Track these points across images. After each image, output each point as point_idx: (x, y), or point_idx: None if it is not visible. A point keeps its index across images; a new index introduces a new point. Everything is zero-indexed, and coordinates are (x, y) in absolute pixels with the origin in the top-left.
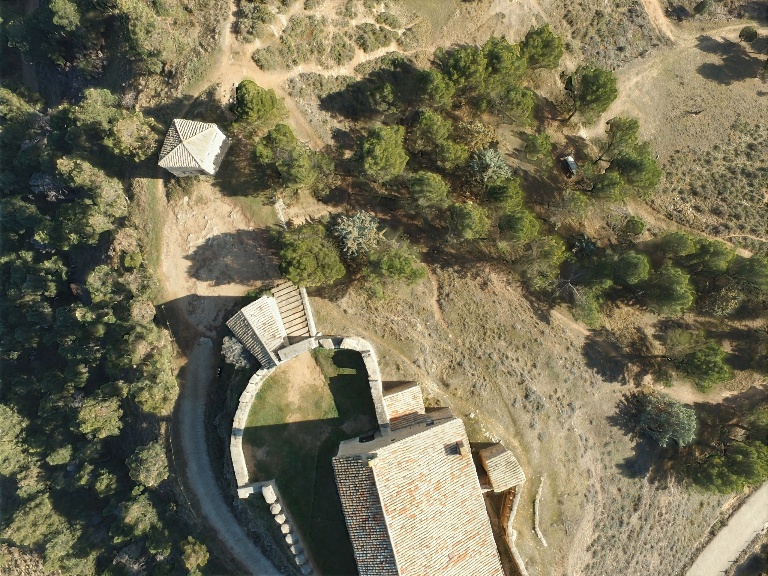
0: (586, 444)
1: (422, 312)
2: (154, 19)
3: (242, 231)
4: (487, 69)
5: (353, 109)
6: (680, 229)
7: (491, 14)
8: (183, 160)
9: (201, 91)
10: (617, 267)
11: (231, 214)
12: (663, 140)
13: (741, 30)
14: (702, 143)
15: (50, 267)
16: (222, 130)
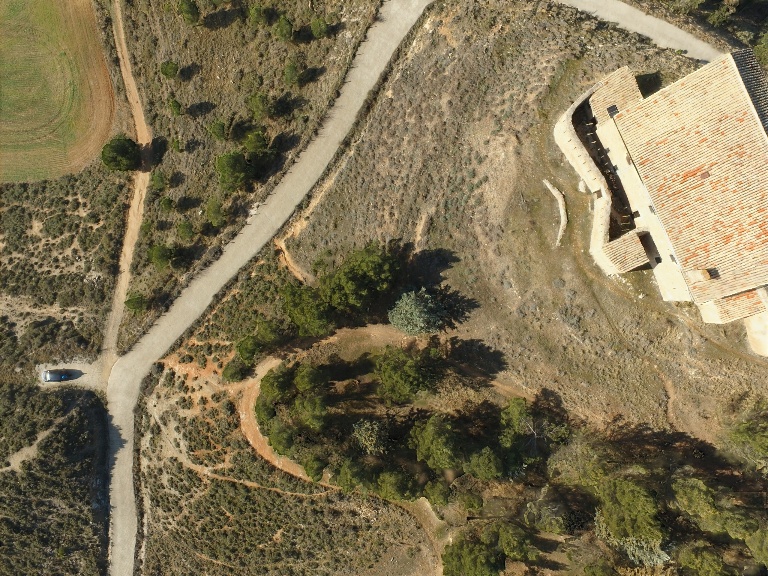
0: (502, 279)
1: (686, 386)
2: None
3: None
4: None
5: None
6: (374, 492)
7: None
8: None
9: None
10: None
11: None
12: None
13: None
14: None
15: None
16: None
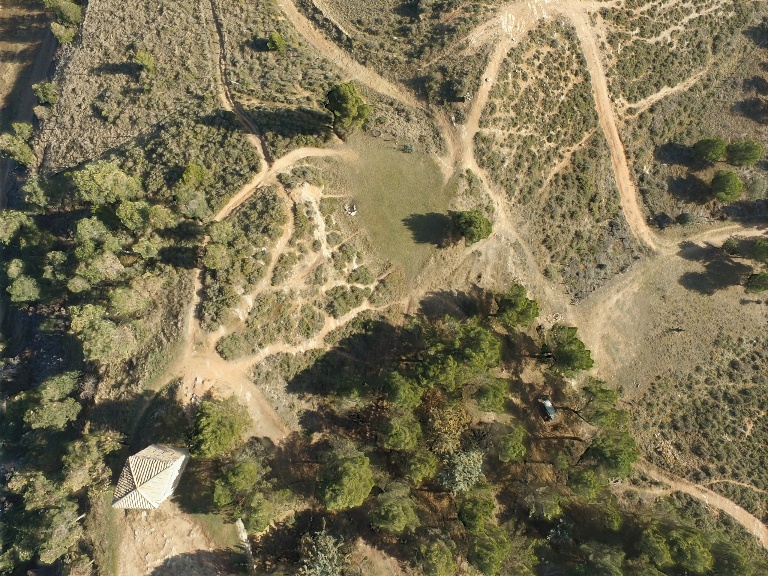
0: None
1: None
2: (110, 339)
3: (202, 552)
4: (458, 366)
5: (322, 385)
6: (660, 473)
7: (467, 254)
8: (138, 503)
9: (162, 386)
10: (592, 574)
11: (191, 533)
12: (644, 365)
13: (723, 243)
14: (684, 364)
15: (4, 566)
16: (183, 435)
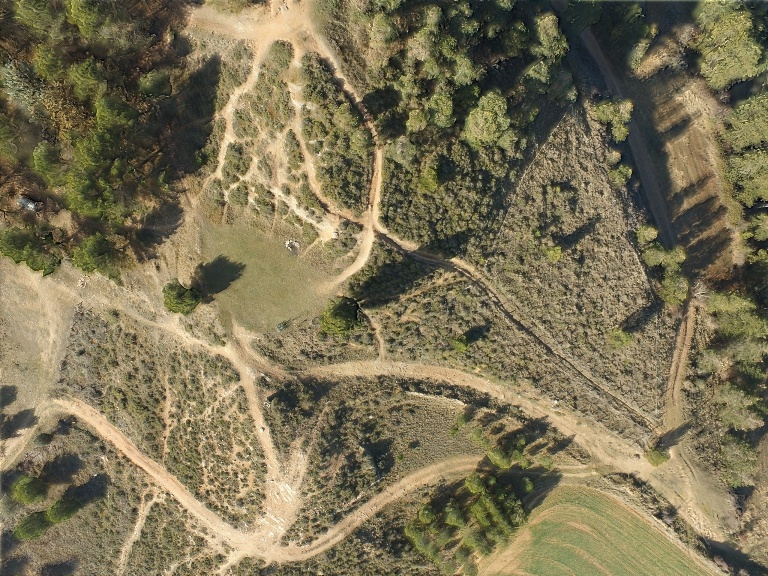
0: None
1: None
2: None
3: None
4: None
5: (198, 81)
6: None
7: (179, 278)
8: None
9: None
10: None
11: None
12: None
13: None
14: None
15: None
16: None
